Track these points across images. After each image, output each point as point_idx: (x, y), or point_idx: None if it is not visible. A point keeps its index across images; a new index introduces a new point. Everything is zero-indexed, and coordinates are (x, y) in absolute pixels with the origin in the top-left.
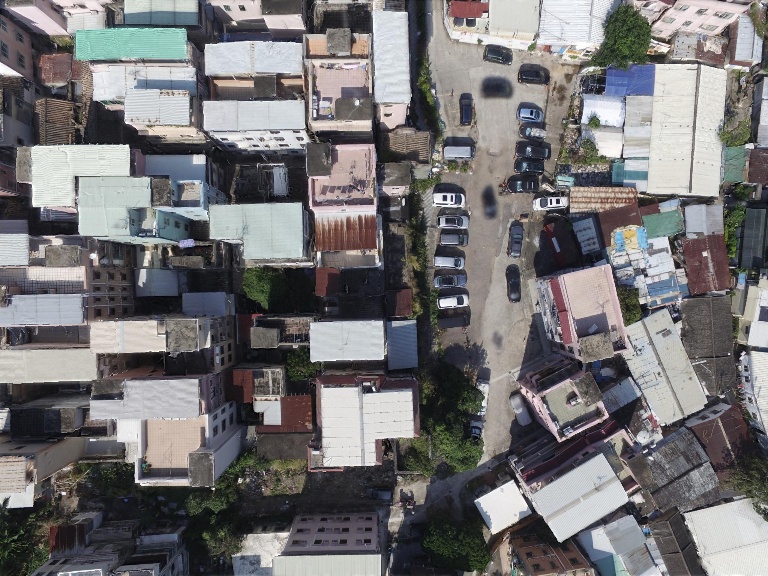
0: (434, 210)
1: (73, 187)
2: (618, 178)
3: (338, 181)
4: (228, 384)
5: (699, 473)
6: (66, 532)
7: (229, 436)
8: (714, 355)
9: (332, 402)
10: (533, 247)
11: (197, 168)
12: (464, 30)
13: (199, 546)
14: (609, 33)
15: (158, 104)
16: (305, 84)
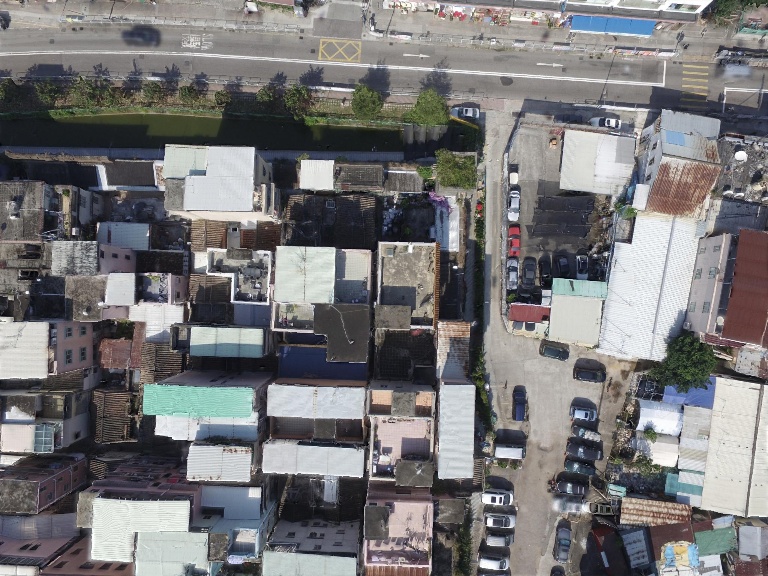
0: (481, 502)
1: (132, 543)
2: (671, 489)
3: (393, 532)
4: None
5: None
6: None
7: None
8: None
9: None
10: (580, 549)
11: (252, 502)
12: (523, 334)
13: None
14: (672, 360)
15: (220, 461)
16: (364, 420)
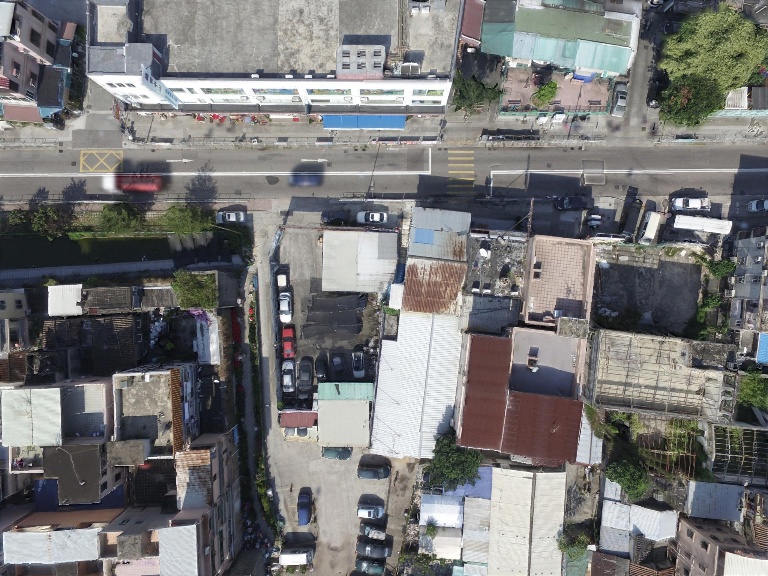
0: None
1: None
2: None
3: None
4: None
5: None
6: None
7: None
8: None
9: None
10: None
11: None
12: (295, 439)
13: None
14: (435, 460)
15: None
16: None
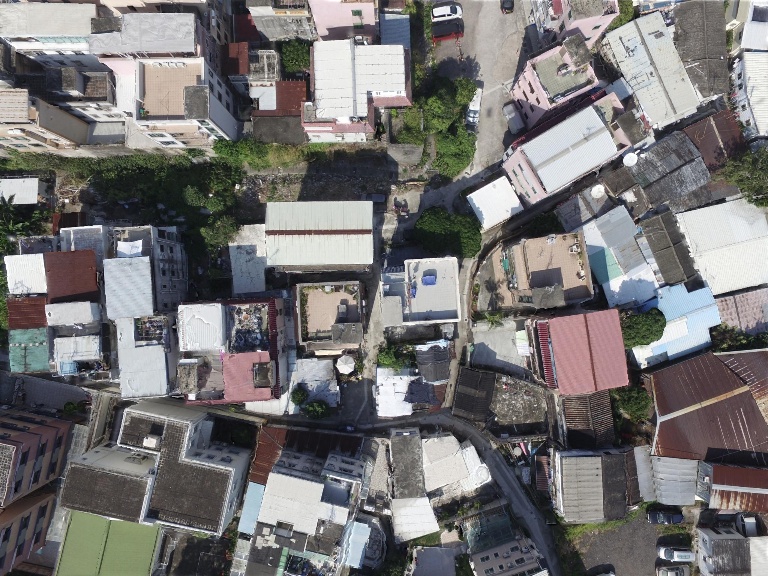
0: None
1: None
2: None
3: None
4: (224, 57)
5: (691, 168)
6: (69, 218)
7: (225, 107)
8: (707, 56)
9: (325, 55)
10: None
11: None
12: None
13: (197, 249)
14: None
15: None
16: None
